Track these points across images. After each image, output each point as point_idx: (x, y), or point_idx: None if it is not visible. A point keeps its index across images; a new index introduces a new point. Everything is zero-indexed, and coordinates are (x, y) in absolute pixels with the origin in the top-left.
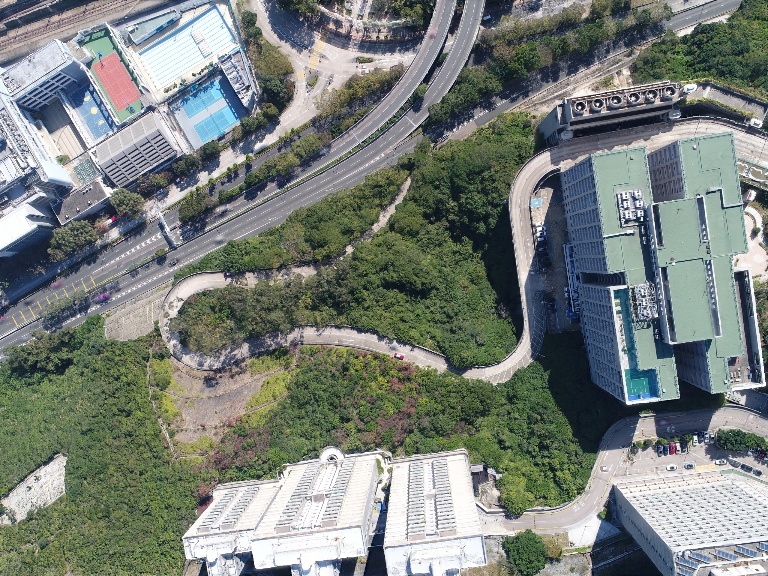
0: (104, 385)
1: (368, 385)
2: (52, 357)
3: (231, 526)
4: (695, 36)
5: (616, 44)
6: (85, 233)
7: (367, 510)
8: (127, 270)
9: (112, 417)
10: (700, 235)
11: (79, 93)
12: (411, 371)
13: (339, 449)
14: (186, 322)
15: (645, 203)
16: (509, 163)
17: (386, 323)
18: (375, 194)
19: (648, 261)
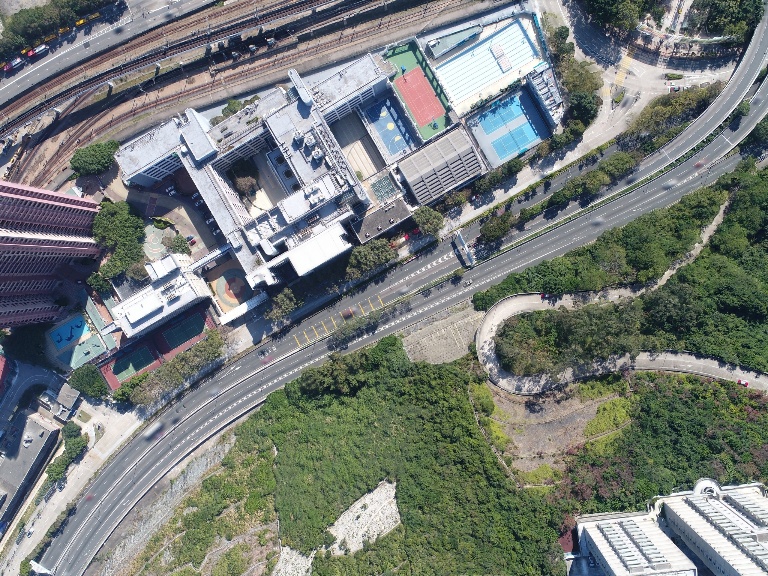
0: (418, 409)
1: (722, 413)
2: (351, 379)
3: (667, 566)
4: None
5: None
6: (385, 252)
7: None
8: (420, 290)
9: (434, 443)
10: None
11: (375, 108)
12: (766, 399)
13: (715, 481)
14: None
15: None
16: None
17: (730, 349)
18: (696, 215)
19: None
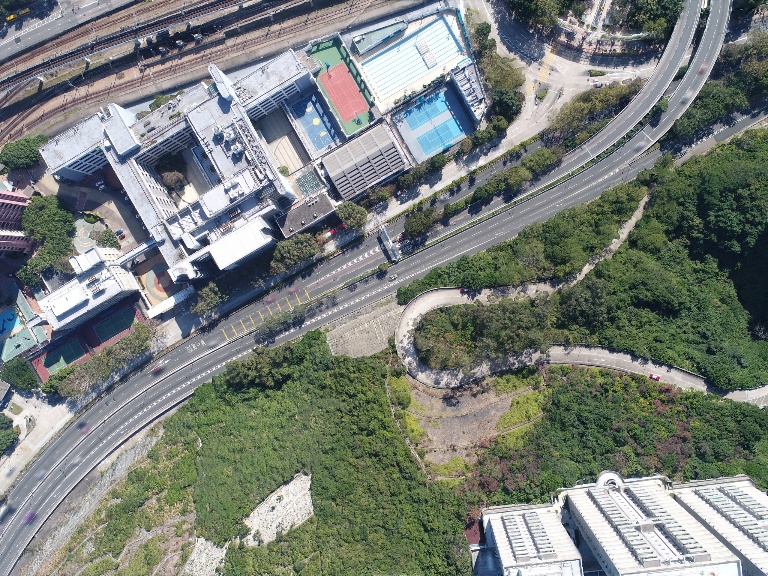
0: (338, 402)
1: (631, 407)
2: (274, 373)
3: (553, 556)
4: None
5: None
6: (309, 246)
7: None
8: (346, 284)
9: (351, 436)
10: None
11: (301, 103)
12: (675, 393)
13: (618, 474)
14: None
15: None
16: None
17: (642, 343)
18: (615, 210)
19: None
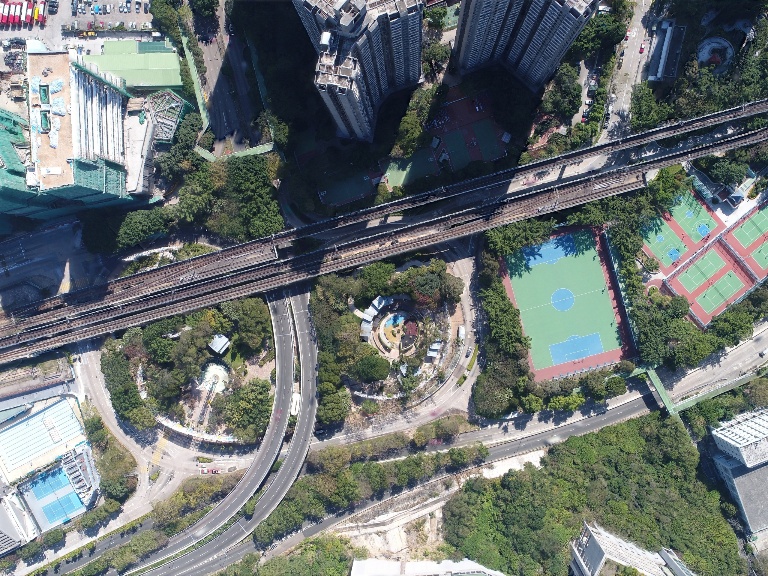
0: None
1: None
2: None
3: None
4: (504, 486)
5: (438, 469)
6: None
7: None
8: None
9: None
10: None
11: None
12: None
13: None
14: None
15: None
16: None
17: None
18: None
19: None
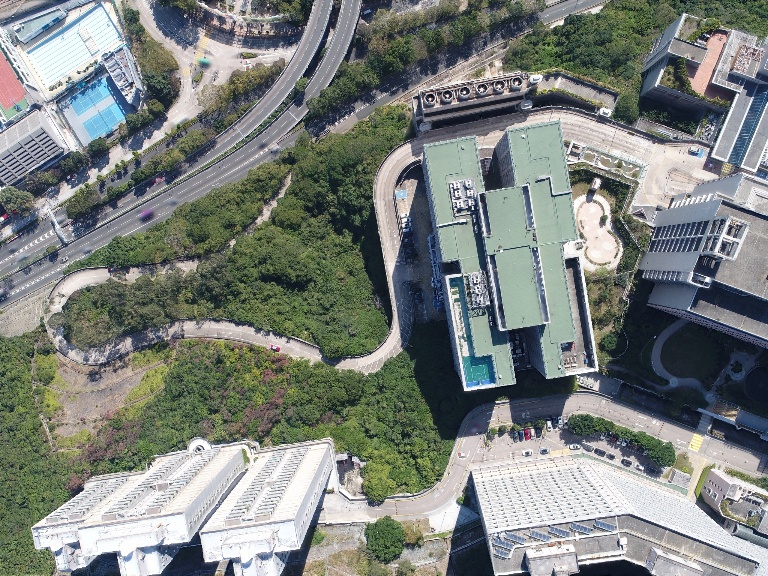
0: None
1: (241, 377)
2: None
3: (79, 516)
4: (565, 27)
5: (493, 36)
6: None
7: (203, 498)
8: (20, 267)
9: None
10: (526, 223)
11: None
12: (284, 362)
13: (206, 440)
14: (69, 318)
15: (475, 192)
16: (380, 155)
17: (262, 315)
18: (257, 188)
19: (481, 249)
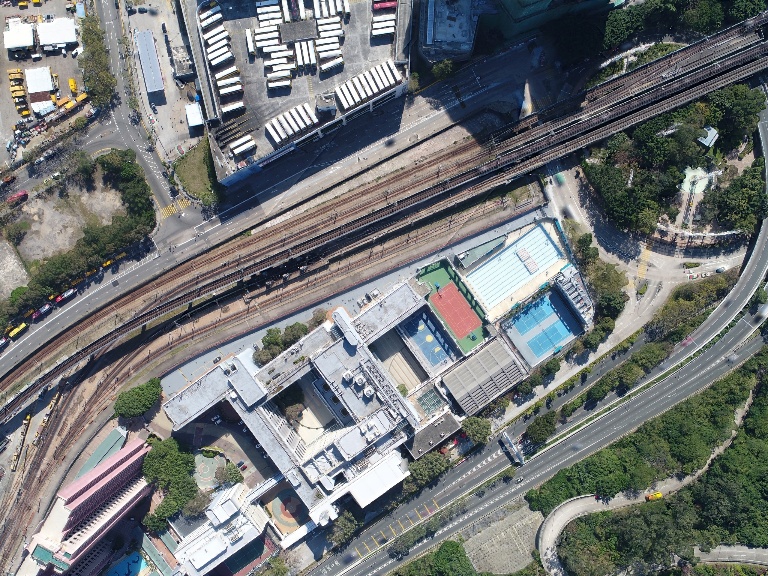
0: None
1: None
2: None
3: None
4: None
5: None
6: (439, 465)
7: None
8: (474, 492)
9: None
10: None
11: (412, 322)
12: None
13: None
14: None
15: None
16: None
17: None
18: None
19: None
